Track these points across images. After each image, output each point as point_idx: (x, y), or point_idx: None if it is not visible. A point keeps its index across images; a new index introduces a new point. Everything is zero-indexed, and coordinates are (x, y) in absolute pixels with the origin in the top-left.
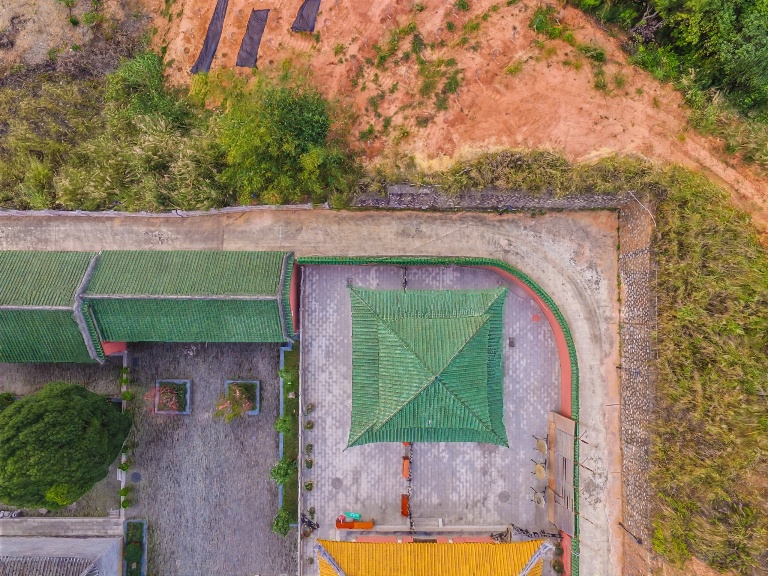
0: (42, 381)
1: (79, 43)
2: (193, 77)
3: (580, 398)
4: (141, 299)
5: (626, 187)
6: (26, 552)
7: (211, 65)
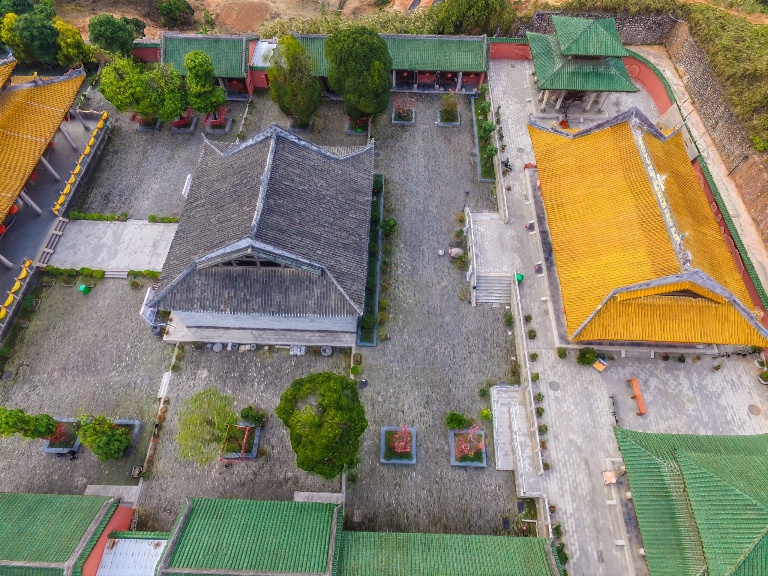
0: (316, 112)
1: None
2: None
3: None
4: (405, 39)
5: (667, 6)
6: None
7: None
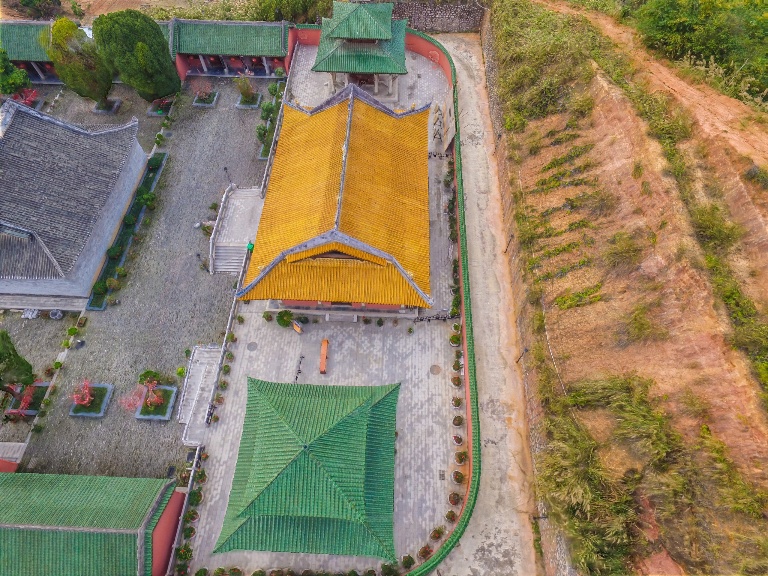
0: (126, 95)
1: None
2: None
3: (463, 99)
4: (207, 24)
5: None
6: None
7: None
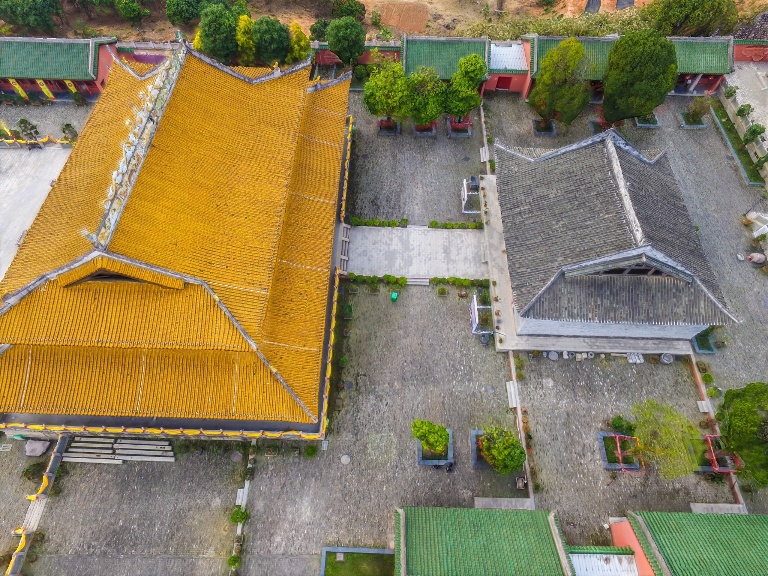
0: None
1: None
2: None
3: None
4: None
5: None
6: None
7: None
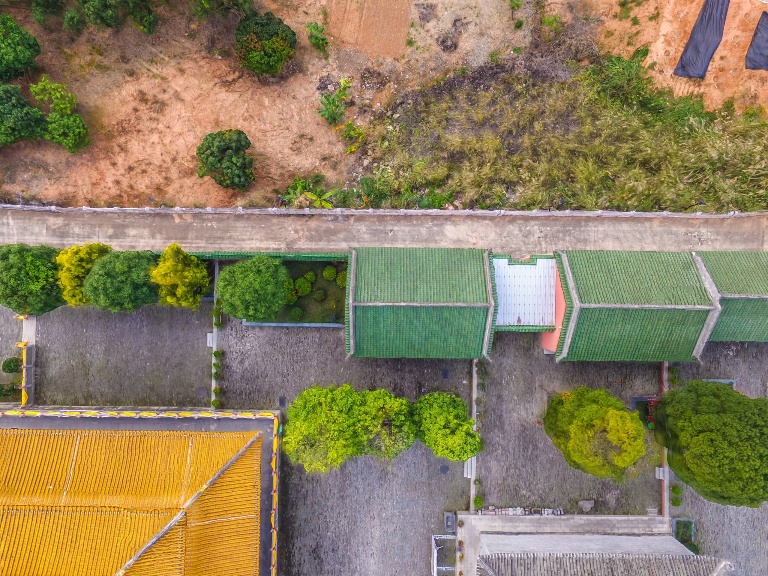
0: (580, 380)
1: (520, 45)
2: (678, 80)
3: None
4: None
5: None
6: (615, 549)
7: (708, 68)
